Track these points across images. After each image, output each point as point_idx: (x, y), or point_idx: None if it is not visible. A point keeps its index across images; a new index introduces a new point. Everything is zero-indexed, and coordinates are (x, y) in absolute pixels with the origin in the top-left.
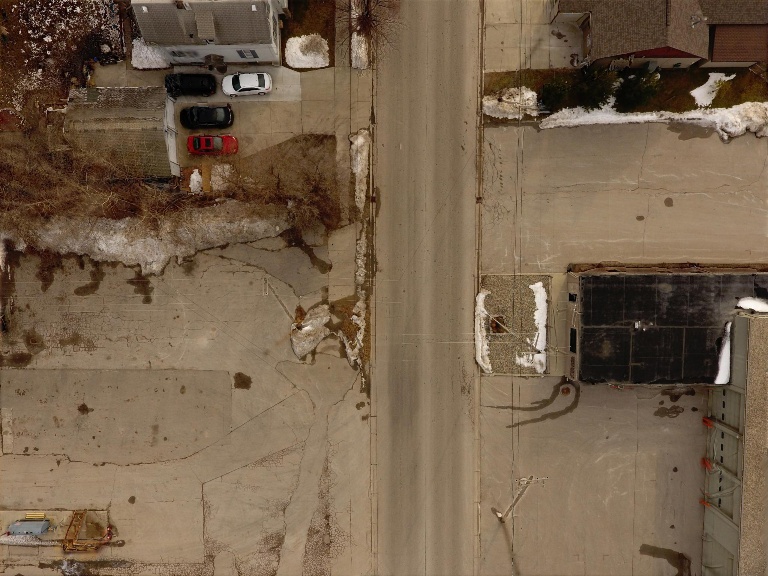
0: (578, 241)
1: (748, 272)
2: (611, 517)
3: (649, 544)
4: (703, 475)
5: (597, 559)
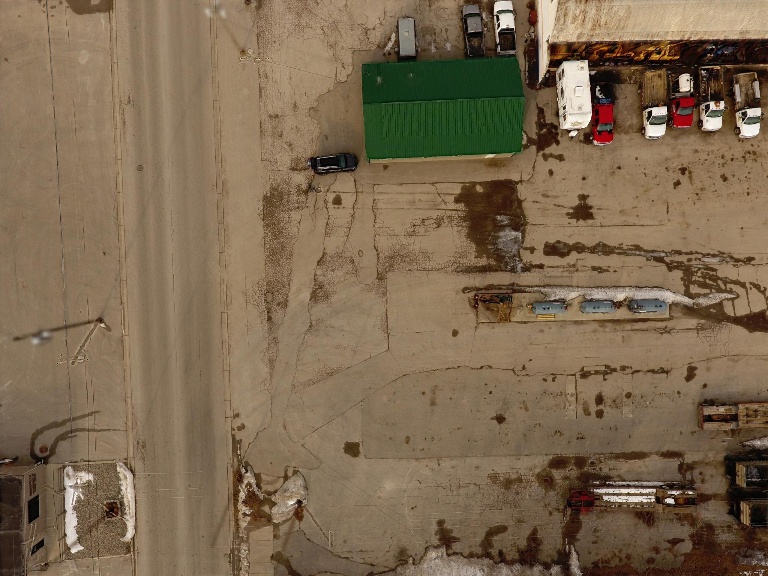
0: None
1: None
2: None
3: None
4: None
5: (4, 284)
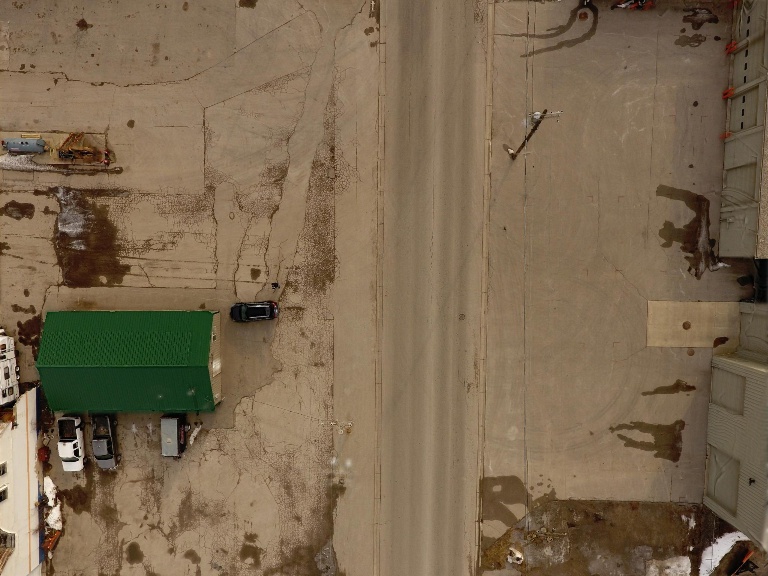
0: None
1: None
2: (627, 155)
3: (666, 185)
4: (727, 66)
5: (612, 201)
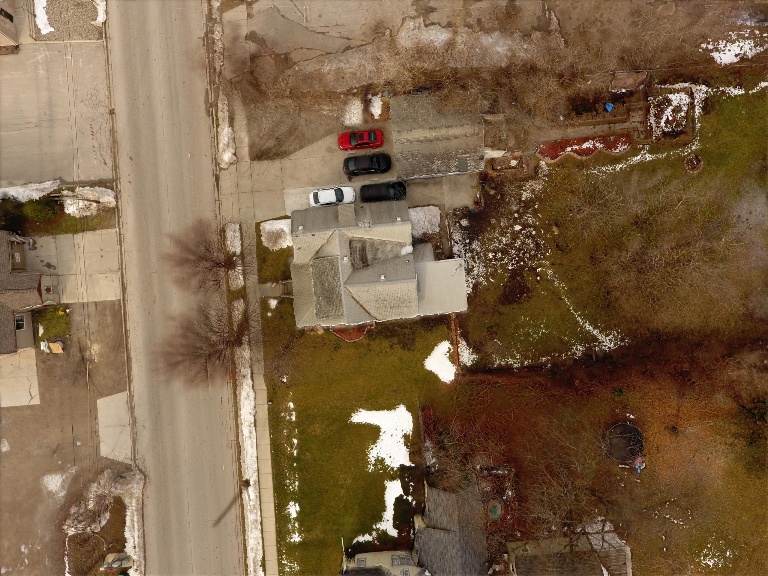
0: (12, 76)
1: None
2: None
3: None
4: None
5: None
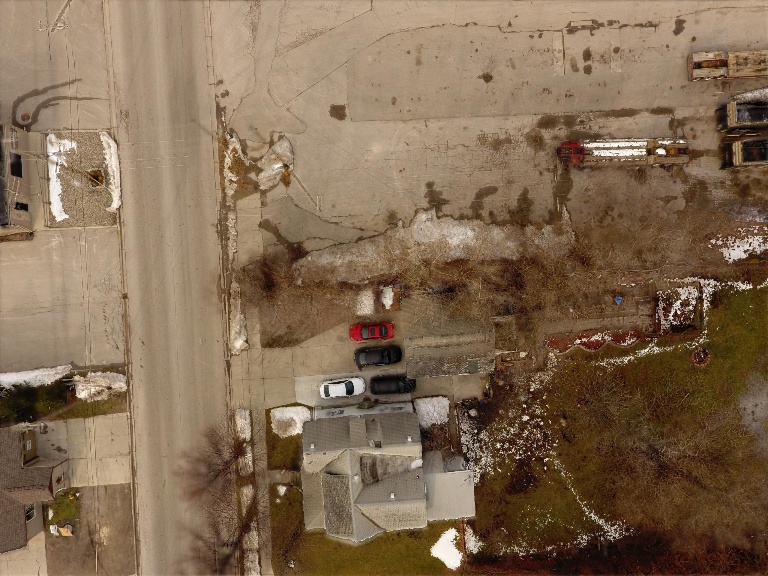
0: (26, 262)
1: None
2: None
3: None
4: None
5: None
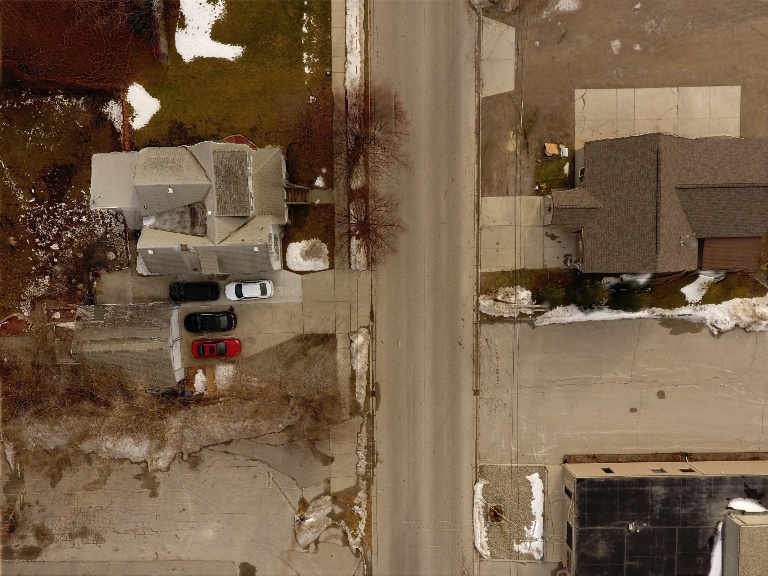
0: (573, 433)
1: (738, 471)
2: None
3: None
4: None
5: None
